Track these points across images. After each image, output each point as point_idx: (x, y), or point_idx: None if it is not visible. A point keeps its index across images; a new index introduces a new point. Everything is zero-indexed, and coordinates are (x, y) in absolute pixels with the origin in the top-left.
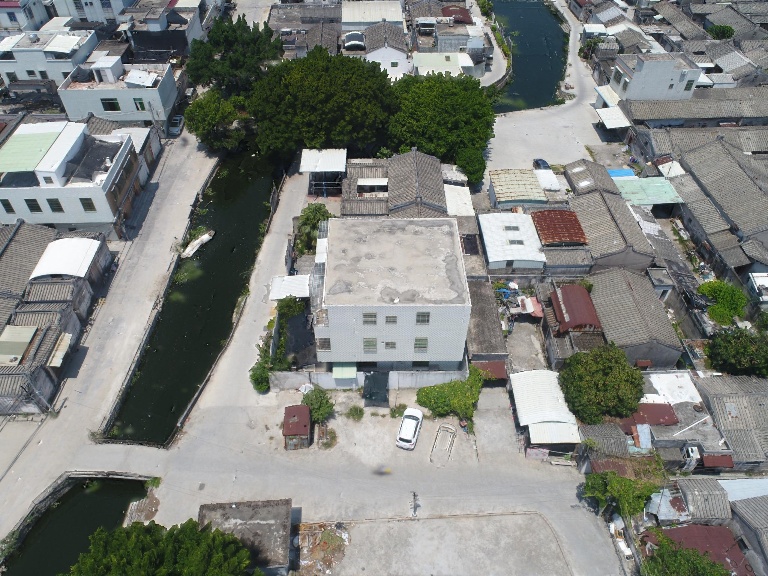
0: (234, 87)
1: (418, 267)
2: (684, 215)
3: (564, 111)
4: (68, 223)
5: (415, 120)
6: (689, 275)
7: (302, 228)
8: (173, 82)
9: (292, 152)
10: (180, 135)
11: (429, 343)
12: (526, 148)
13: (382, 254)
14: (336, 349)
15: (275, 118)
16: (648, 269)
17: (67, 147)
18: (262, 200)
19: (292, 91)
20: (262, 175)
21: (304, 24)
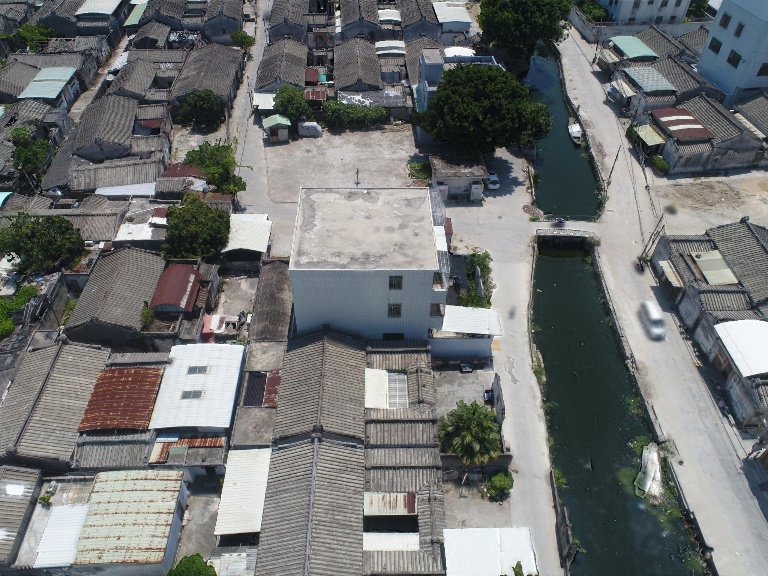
0: None
1: (342, 219)
2: None
3: None
4: None
5: None
6: None
7: None
8: None
9: None
10: None
11: None
12: None
13: (377, 231)
14: None
15: None
16: None
17: None
18: None
19: None
20: None
21: None
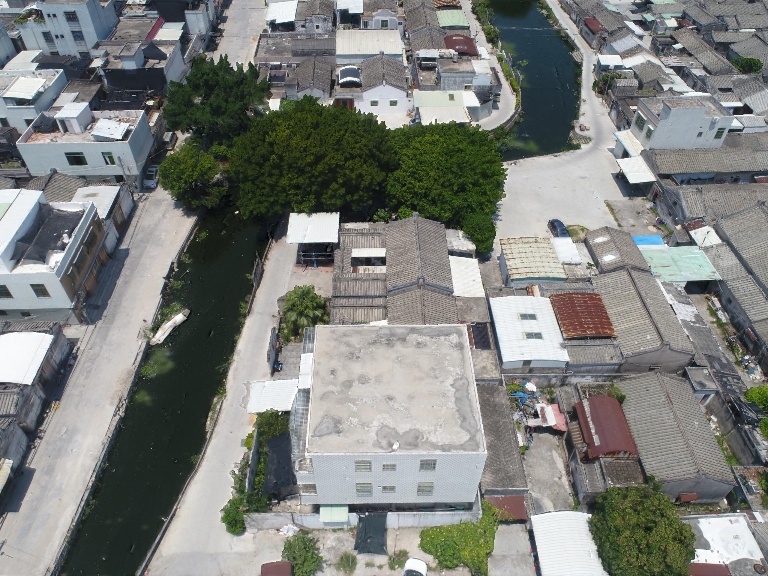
0: (216, 134)
1: (422, 395)
2: (723, 295)
3: (580, 158)
4: (19, 309)
5: (416, 180)
6: (734, 374)
7: (287, 314)
8: (148, 130)
9: (278, 215)
10: (156, 188)
11: (435, 487)
12: (539, 204)
13: (378, 376)
14: (323, 493)
15: (258, 180)
16: (687, 369)
17: (17, 223)
18: (245, 269)
19: (277, 152)
20: (246, 236)
21: (295, 57)
